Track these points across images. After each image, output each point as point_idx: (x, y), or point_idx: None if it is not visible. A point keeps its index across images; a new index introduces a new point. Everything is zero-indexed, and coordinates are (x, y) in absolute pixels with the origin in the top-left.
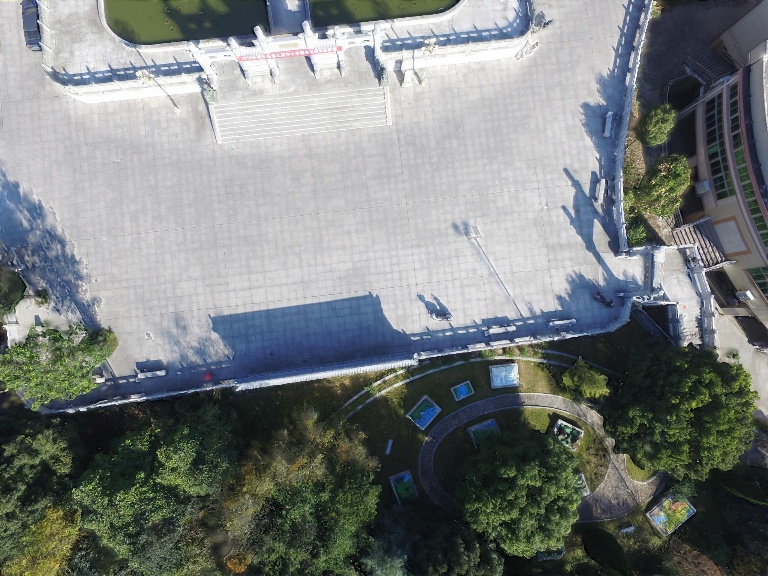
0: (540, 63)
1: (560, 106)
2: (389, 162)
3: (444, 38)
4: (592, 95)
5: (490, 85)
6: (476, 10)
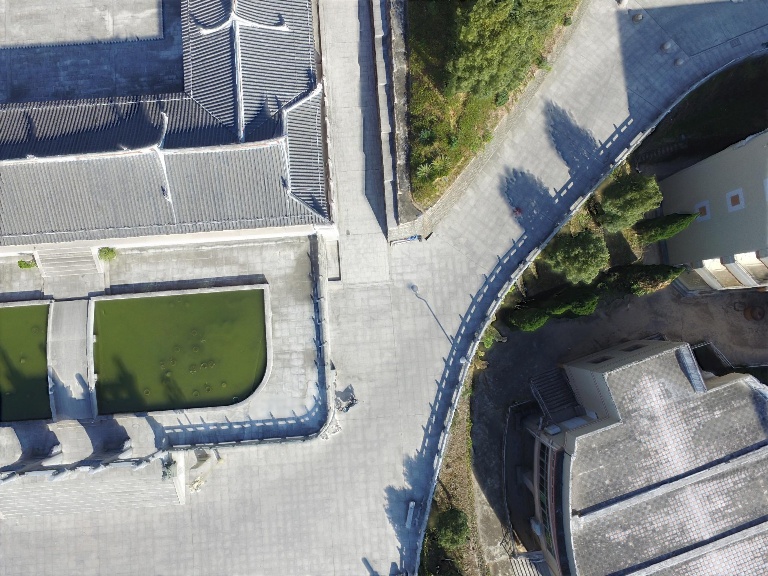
0: (345, 441)
1: (363, 489)
2: (180, 545)
3: (238, 426)
4: (397, 478)
5: (291, 464)
6: (274, 396)
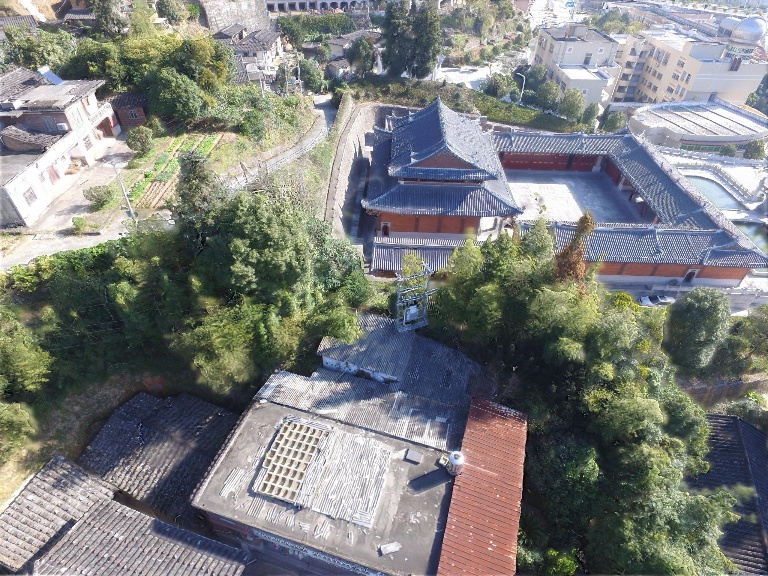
0: None
1: (728, 171)
2: None
3: None
4: None
5: None
6: None
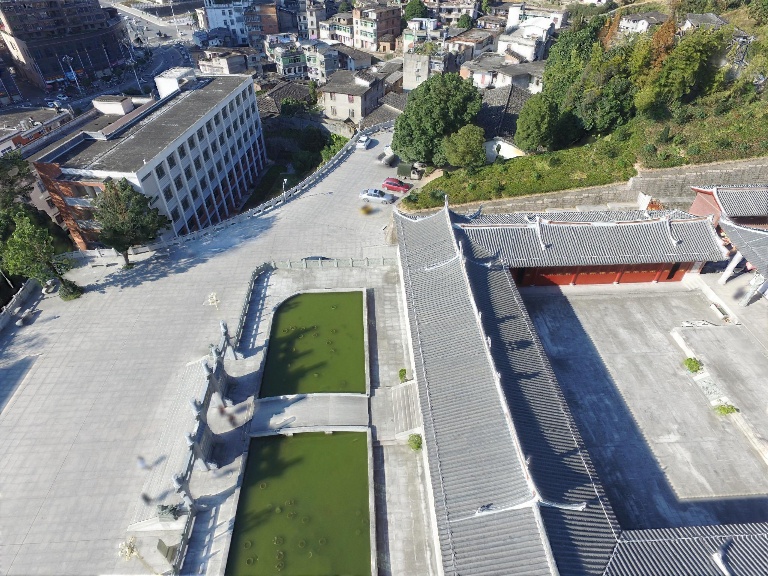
0: None
1: None
2: (84, 525)
3: None
4: None
5: None
6: None
